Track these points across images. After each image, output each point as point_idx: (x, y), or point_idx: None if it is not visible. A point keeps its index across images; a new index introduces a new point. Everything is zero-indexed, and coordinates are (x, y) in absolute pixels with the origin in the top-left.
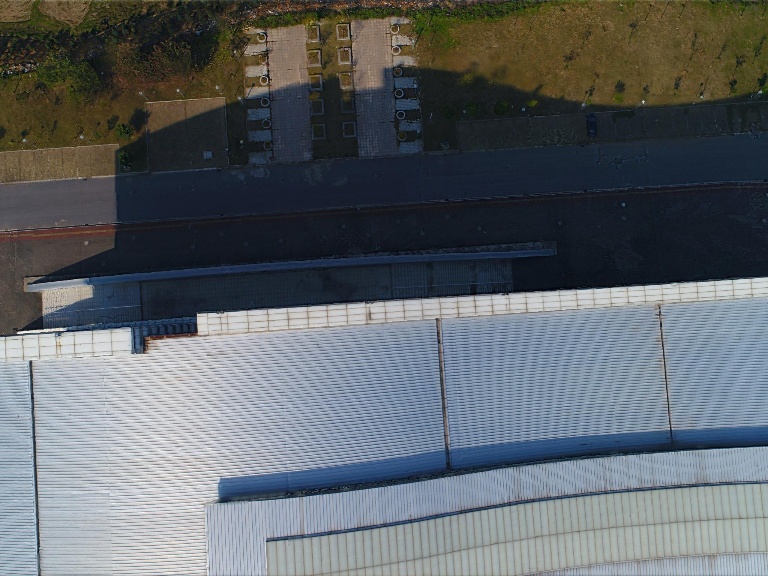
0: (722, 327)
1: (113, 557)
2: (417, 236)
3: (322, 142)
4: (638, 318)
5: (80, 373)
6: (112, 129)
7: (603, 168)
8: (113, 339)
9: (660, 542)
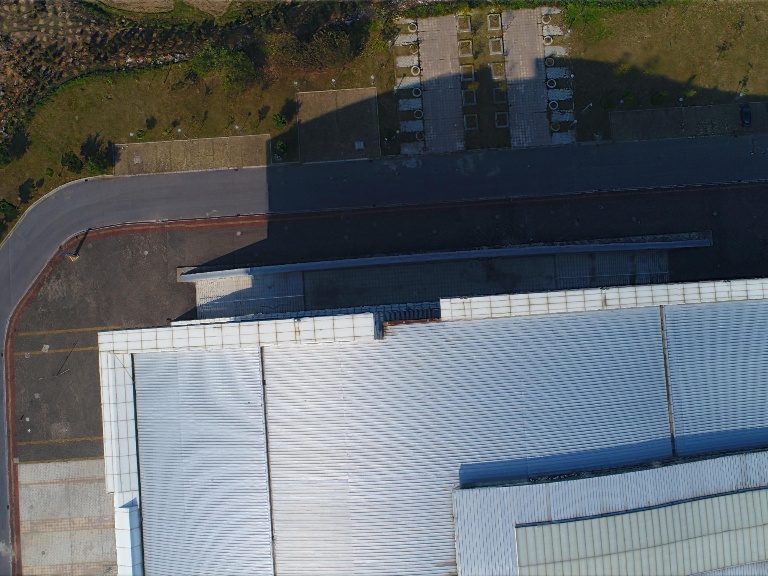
0: None
1: (353, 543)
2: (571, 227)
3: (474, 132)
4: None
5: (315, 359)
6: (263, 119)
7: (757, 158)
8: (355, 324)
9: None
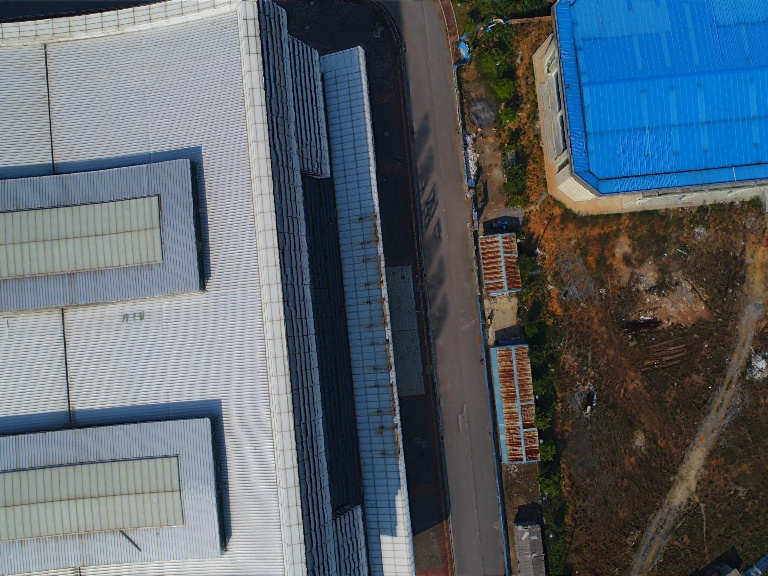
0: (102, 63)
1: None
2: None
3: None
4: (23, 57)
5: None
6: None
7: None
8: None
9: (19, 261)
